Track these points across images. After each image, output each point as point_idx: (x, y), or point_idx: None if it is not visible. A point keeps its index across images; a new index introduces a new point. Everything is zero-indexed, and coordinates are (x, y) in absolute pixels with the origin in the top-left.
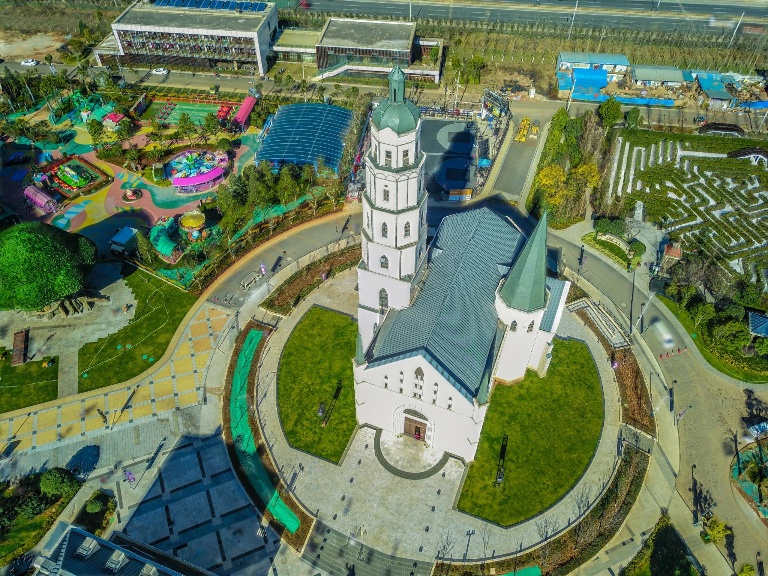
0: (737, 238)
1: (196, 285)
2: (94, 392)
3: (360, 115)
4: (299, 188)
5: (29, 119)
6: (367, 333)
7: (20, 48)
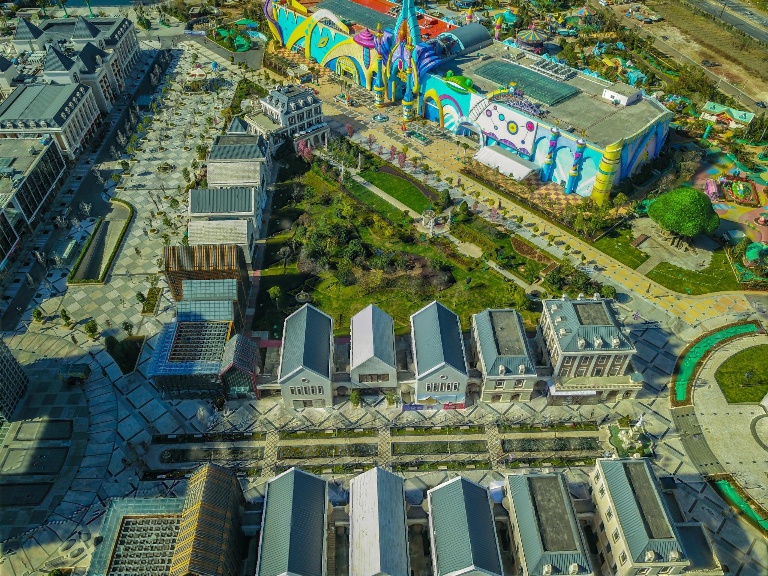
0: None
1: (747, 284)
2: (651, 281)
3: None
4: None
5: (747, 147)
6: None
7: None
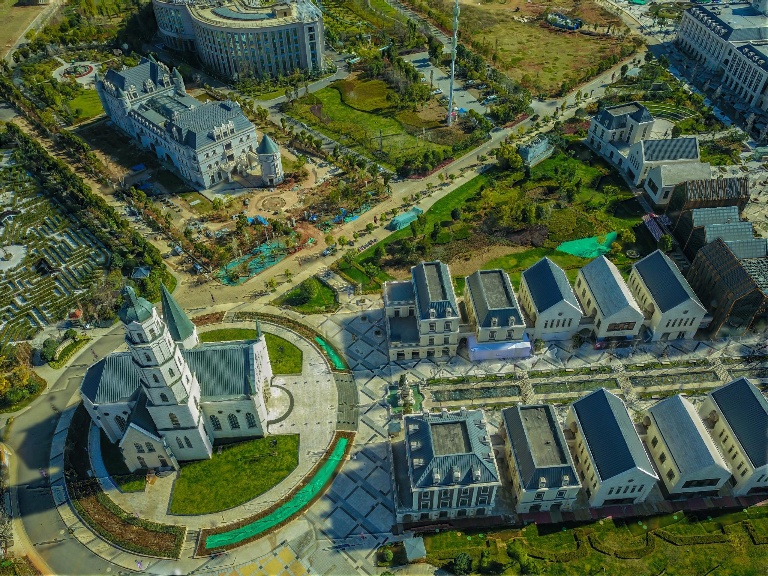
0: (52, 292)
1: None
2: None
3: None
4: None
5: None
6: (205, 437)
7: None
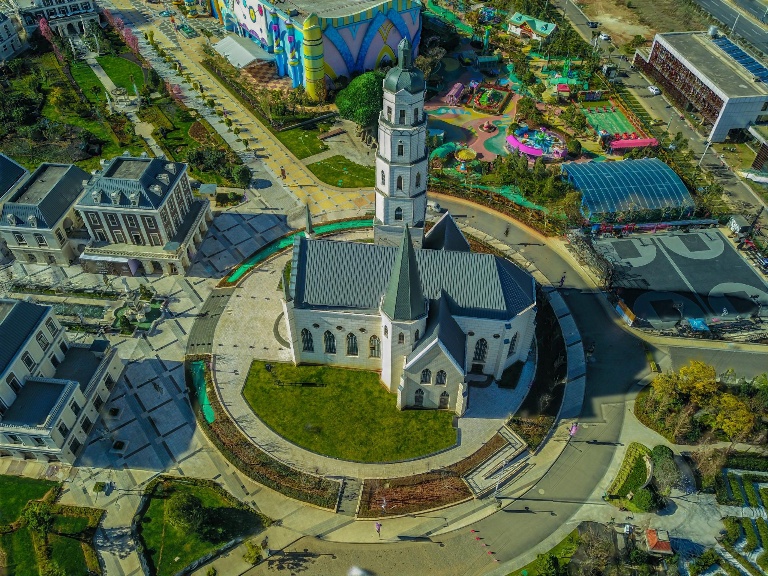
0: None
1: None
2: (308, 171)
3: (687, 207)
4: (554, 203)
5: (537, 61)
6: None
7: (619, 27)
